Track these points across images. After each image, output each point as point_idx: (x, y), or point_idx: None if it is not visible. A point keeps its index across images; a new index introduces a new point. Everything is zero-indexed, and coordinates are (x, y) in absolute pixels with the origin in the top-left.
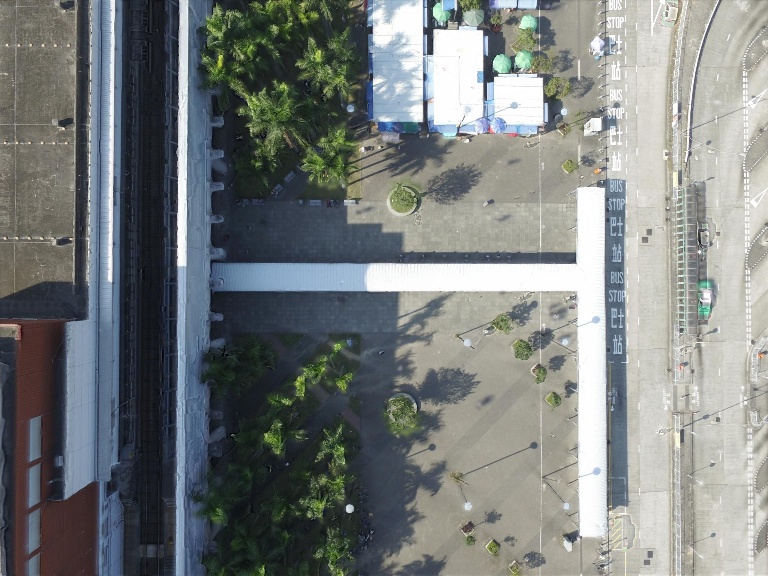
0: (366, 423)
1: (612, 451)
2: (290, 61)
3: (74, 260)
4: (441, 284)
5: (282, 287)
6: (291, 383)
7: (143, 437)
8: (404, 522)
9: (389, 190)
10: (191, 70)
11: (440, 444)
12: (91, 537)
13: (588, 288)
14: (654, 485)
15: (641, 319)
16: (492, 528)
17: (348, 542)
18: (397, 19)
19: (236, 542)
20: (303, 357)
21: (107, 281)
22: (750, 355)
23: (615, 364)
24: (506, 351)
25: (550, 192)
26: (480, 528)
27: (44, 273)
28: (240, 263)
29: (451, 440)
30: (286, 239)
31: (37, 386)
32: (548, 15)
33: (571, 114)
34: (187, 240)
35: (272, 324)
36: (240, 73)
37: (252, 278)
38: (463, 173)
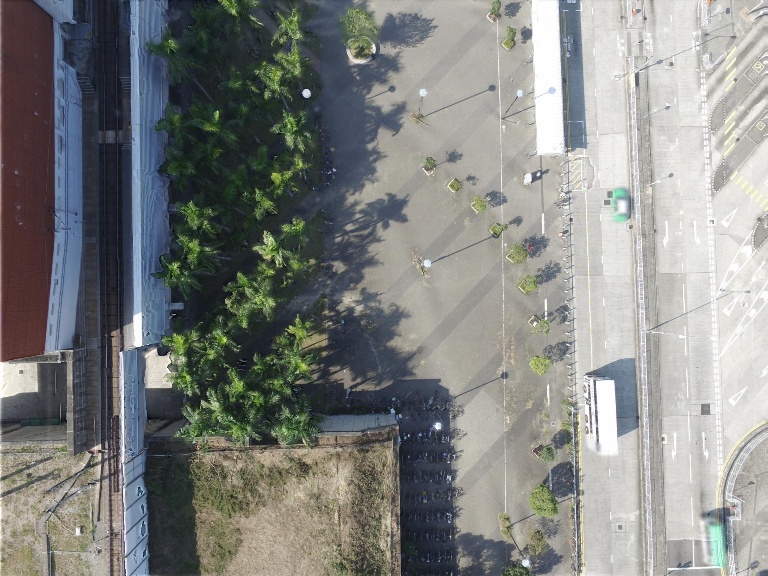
0: (326, 66)
1: (569, 95)
2: None
3: None
4: None
5: None
6: None
7: (100, 30)
8: (366, 161)
9: None
10: None
11: (400, 86)
12: (45, 74)
13: None
14: (611, 128)
15: None
16: (453, 167)
17: (304, 113)
18: None
19: (192, 109)
20: (262, 2)
21: None
22: (700, 2)
23: (569, 12)
24: None
25: None
26: (441, 168)
27: None
28: None
29: (410, 82)
30: None
31: None
32: None
33: None
34: None
35: None
36: None
37: None
38: None
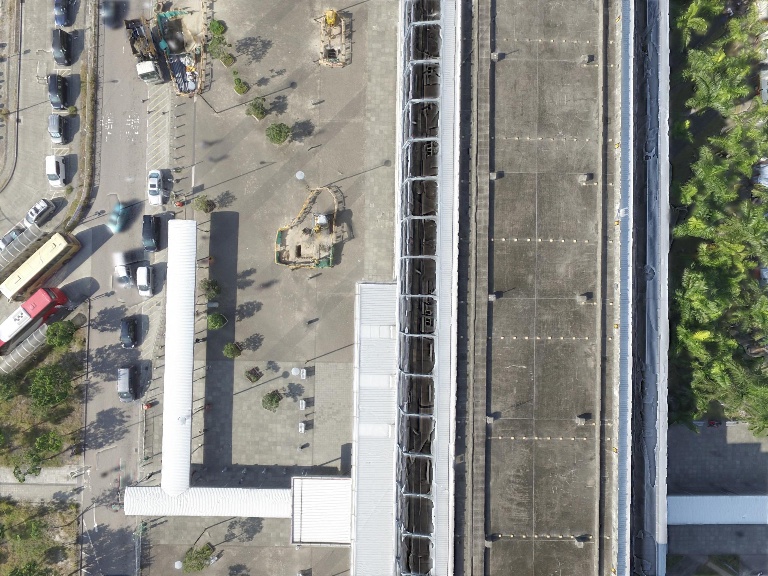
0: None
1: None
2: None
3: None
4: None
5: (685, 521)
6: None
7: None
8: None
9: None
10: (669, 341)
11: None
12: None
13: None
14: None
15: None
16: None
17: None
18: None
19: None
20: None
21: None
22: None
23: None
24: None
25: None
26: None
27: (562, 571)
28: None
29: None
30: None
31: None
32: None
33: None
34: None
35: (653, 545)
36: (712, 341)
37: None
38: None
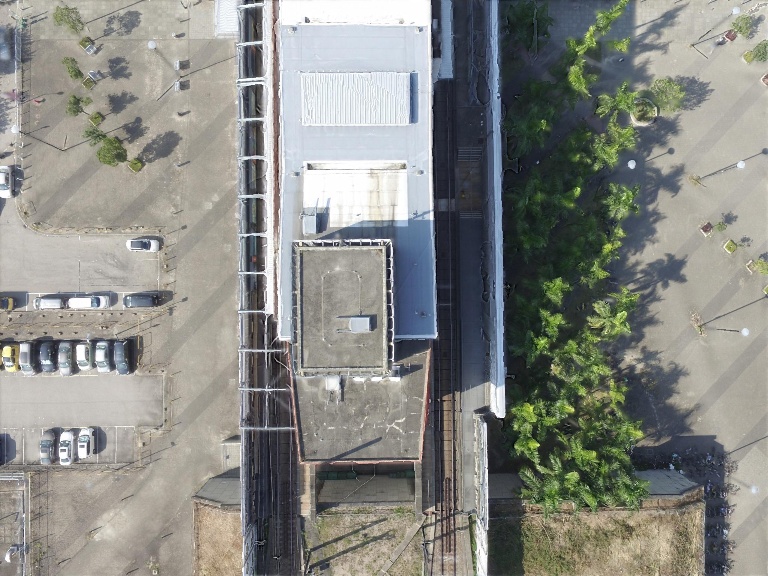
0: None
1: None
2: None
3: None
4: None
5: None
6: (577, 40)
7: None
8: (647, 222)
9: None
10: None
11: (679, 148)
12: None
13: None
14: None
15: None
16: (729, 229)
17: (639, 186)
18: None
19: (537, 182)
20: (547, 63)
21: None
22: None
23: None
24: (737, 61)
25: None
26: None
27: None
28: None
29: (689, 144)
30: None
31: None
32: None
33: None
34: None
35: None
36: None
37: None
38: None
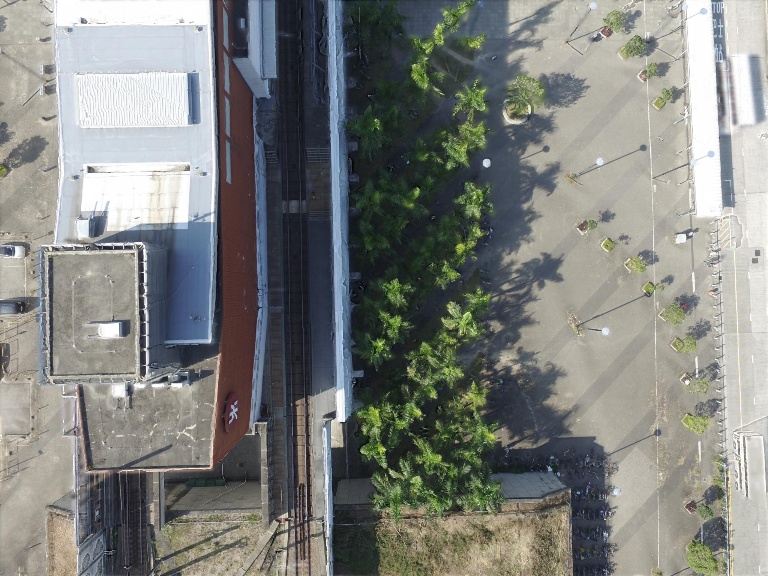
0: None
1: None
2: None
3: None
4: None
5: None
6: (428, 38)
7: (282, 99)
8: (522, 221)
9: None
10: None
11: (554, 146)
12: (251, 152)
13: None
14: (759, 187)
15: (740, 29)
16: (607, 227)
17: (490, 185)
18: None
19: (383, 182)
20: None
21: None
22: None
23: (717, 72)
24: (613, 57)
25: None
26: None
27: None
28: None
29: (564, 142)
30: None
31: None
32: None
33: None
34: None
35: None
36: None
37: None
38: None
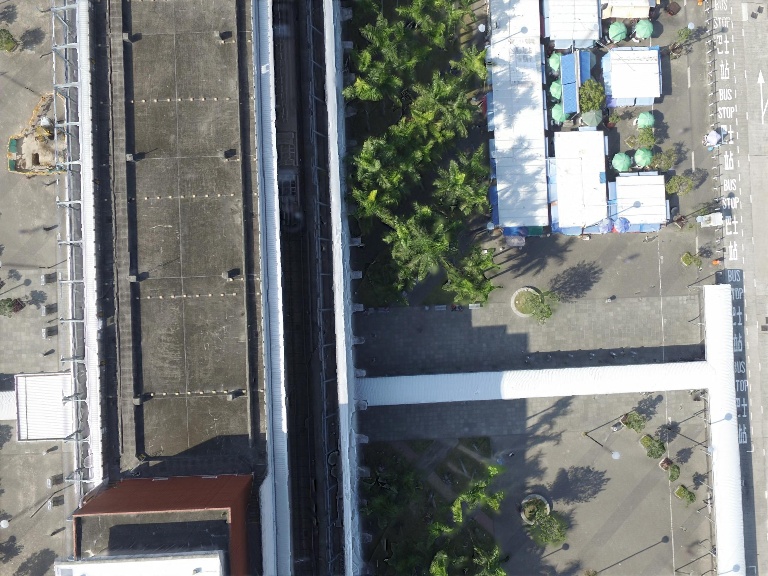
0: (499, 526)
1: None
2: (428, 181)
3: (249, 414)
4: (574, 388)
5: (418, 400)
6: (445, 507)
7: (296, 566)
8: None
9: (512, 291)
10: (343, 204)
11: (573, 543)
12: None
13: (718, 385)
14: None
15: (764, 407)
16: None
17: None
18: (518, 123)
19: None
20: (434, 463)
21: (281, 432)
22: None
23: (740, 453)
24: (634, 446)
25: (670, 285)
26: None
27: (218, 427)
28: (375, 377)
29: (584, 539)
30: (412, 345)
31: (239, 560)
32: (661, 108)
33: (687, 206)
34: (347, 377)
35: (402, 431)
36: (390, 204)
37: (388, 392)
38: (584, 270)
